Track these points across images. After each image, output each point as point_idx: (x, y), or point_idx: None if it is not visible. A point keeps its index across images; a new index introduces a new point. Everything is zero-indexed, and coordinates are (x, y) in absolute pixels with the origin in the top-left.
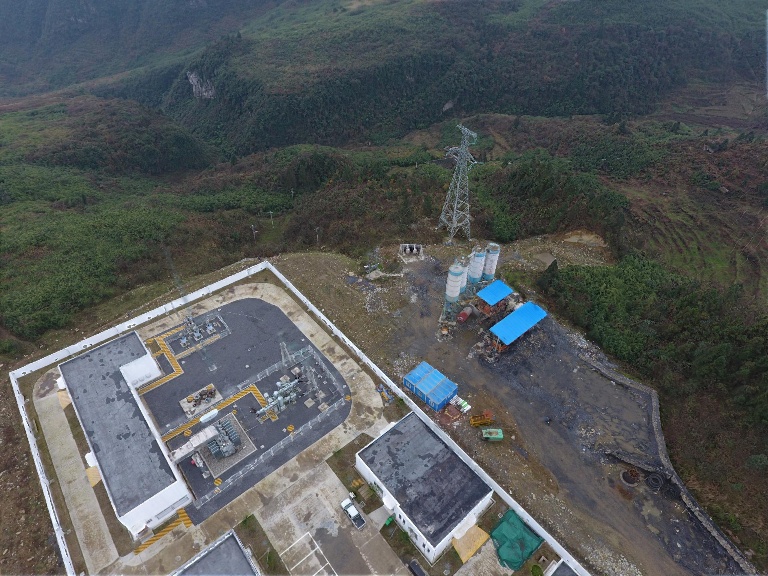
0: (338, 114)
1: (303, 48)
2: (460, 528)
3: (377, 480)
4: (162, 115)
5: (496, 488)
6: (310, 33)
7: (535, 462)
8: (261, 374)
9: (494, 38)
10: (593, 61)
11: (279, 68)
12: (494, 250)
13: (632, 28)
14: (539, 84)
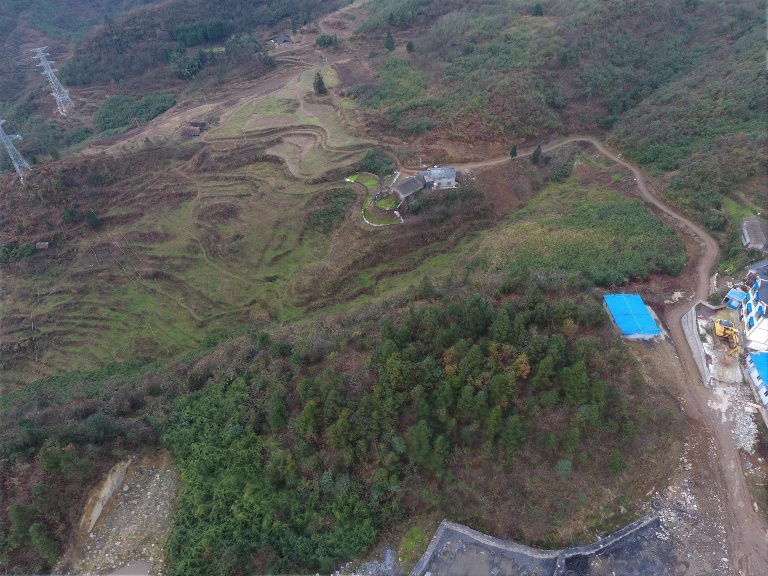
0: None
1: None
2: None
3: None
4: None
5: None
6: None
7: None
8: None
9: None
10: None
11: None
12: None
13: None
14: None
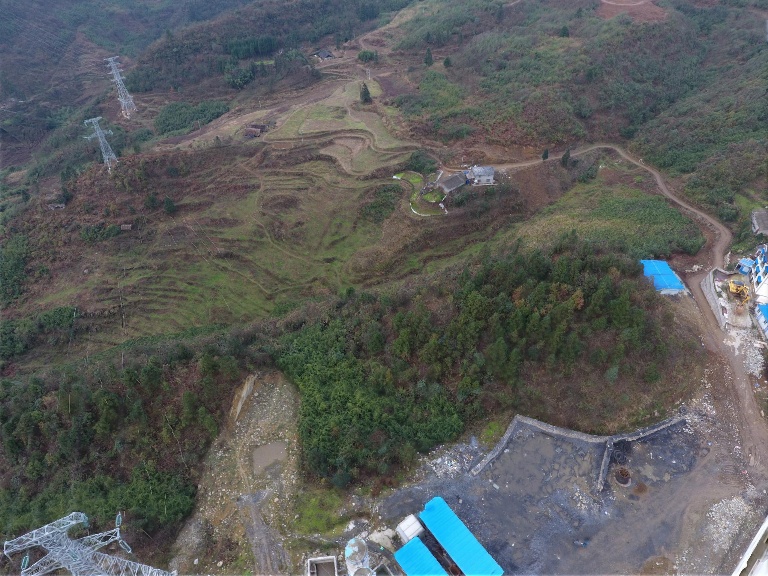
0: None
1: None
2: None
3: None
4: None
5: None
6: None
7: None
8: None
9: None
10: None
11: None
12: (366, 551)
13: None
14: None
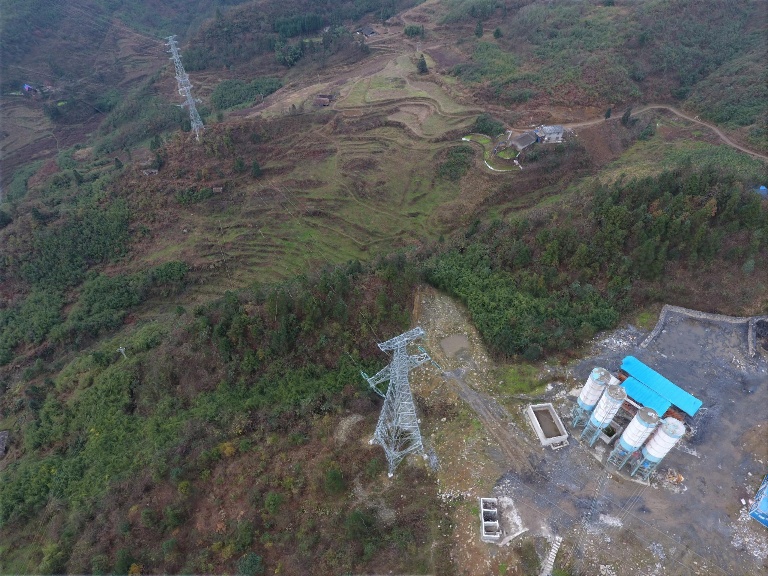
0: None
1: None
2: None
3: None
4: None
5: None
6: None
7: None
8: None
9: None
10: None
11: None
12: None
13: None
14: None
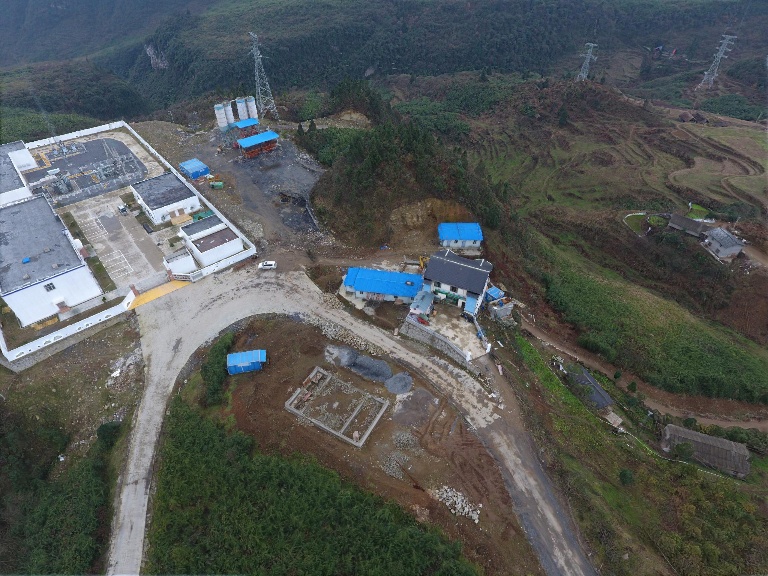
0: (269, 77)
1: (241, 22)
2: (172, 208)
3: (136, 192)
4: (112, 74)
5: (206, 202)
6: (250, 9)
7: (236, 195)
8: (96, 165)
9: (409, 12)
10: (490, 30)
11: (219, 38)
12: (249, 99)
13: (526, 2)
14: (445, 51)
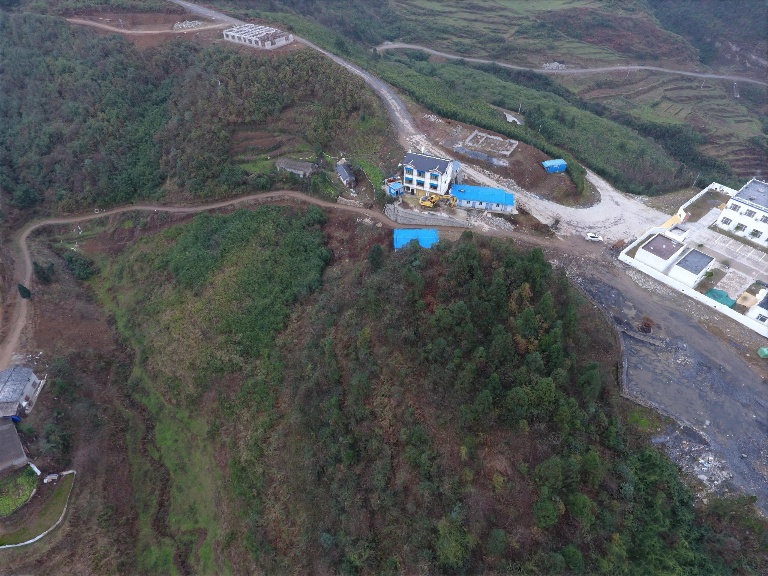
0: None
1: None
2: None
3: None
4: None
5: None
6: None
7: (723, 338)
8: None
9: None
10: None
11: None
12: None
13: None
14: None
